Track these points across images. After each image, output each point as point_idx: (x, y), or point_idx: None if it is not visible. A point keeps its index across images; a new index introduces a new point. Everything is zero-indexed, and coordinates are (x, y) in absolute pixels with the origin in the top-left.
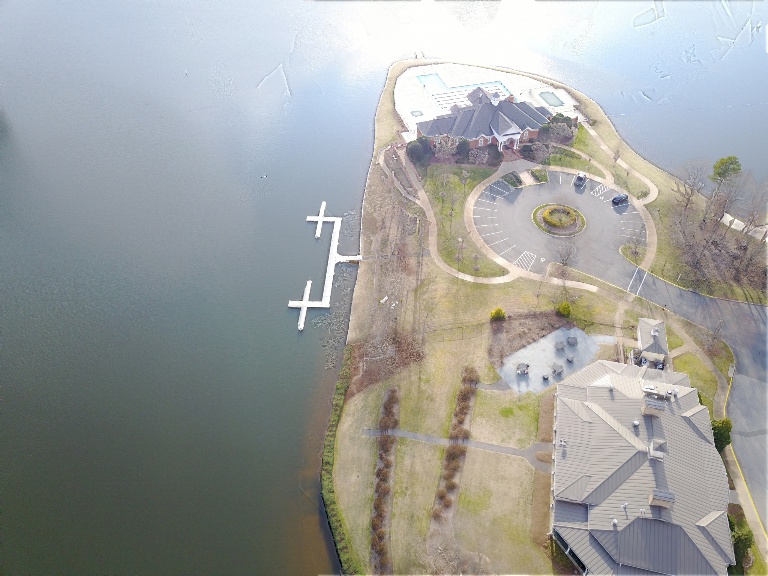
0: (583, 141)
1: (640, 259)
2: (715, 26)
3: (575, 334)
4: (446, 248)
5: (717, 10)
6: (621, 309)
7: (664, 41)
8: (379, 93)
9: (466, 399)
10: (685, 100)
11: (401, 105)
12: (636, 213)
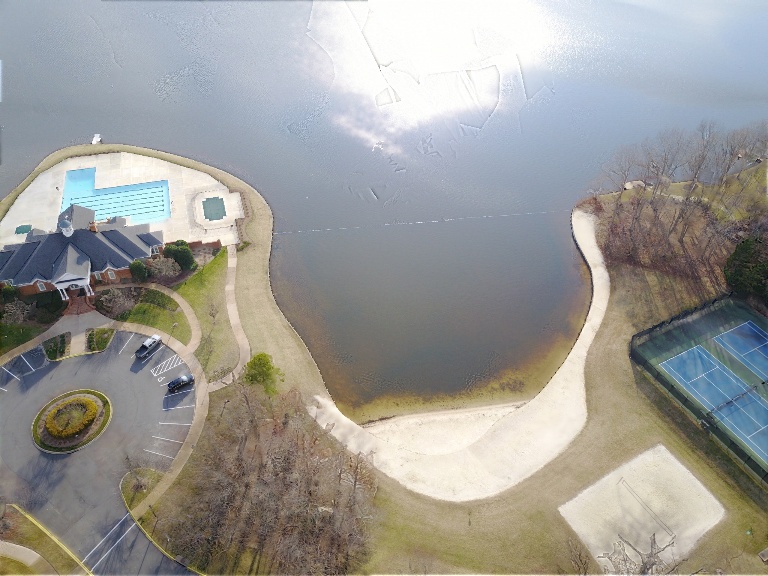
0: (204, 279)
1: (139, 497)
2: (441, 116)
3: None
4: None
5: (460, 92)
6: None
7: (400, 127)
8: (8, 194)
9: None
10: (415, 201)
11: (13, 215)
12: (191, 407)
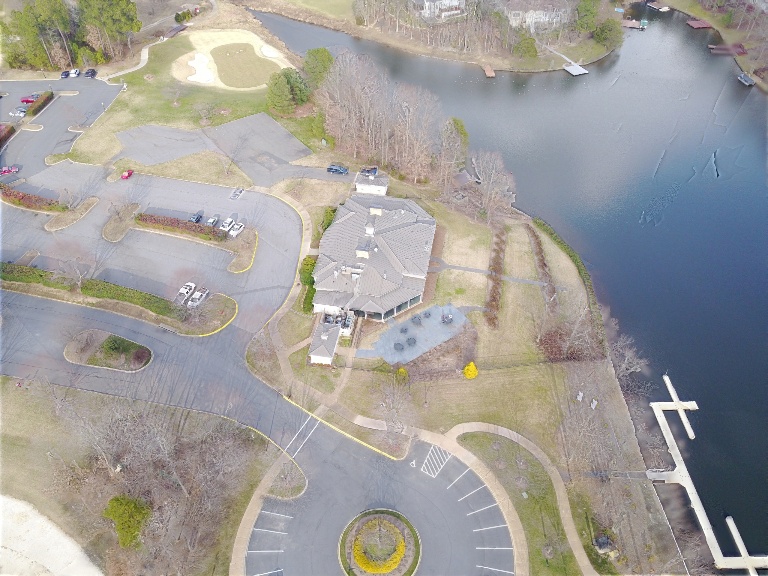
0: None
1: None
2: None
3: (394, 357)
4: (541, 482)
5: None
6: (337, 392)
7: None
8: None
9: (493, 300)
10: None
11: None
12: (251, 574)
